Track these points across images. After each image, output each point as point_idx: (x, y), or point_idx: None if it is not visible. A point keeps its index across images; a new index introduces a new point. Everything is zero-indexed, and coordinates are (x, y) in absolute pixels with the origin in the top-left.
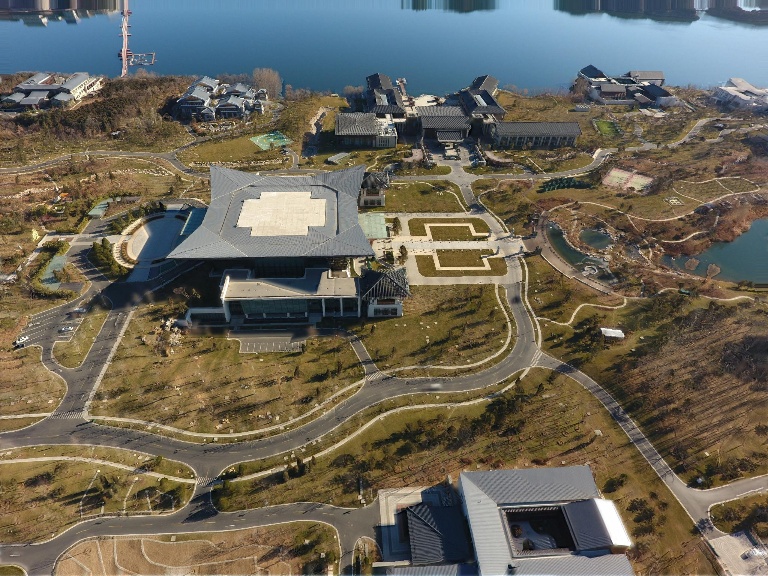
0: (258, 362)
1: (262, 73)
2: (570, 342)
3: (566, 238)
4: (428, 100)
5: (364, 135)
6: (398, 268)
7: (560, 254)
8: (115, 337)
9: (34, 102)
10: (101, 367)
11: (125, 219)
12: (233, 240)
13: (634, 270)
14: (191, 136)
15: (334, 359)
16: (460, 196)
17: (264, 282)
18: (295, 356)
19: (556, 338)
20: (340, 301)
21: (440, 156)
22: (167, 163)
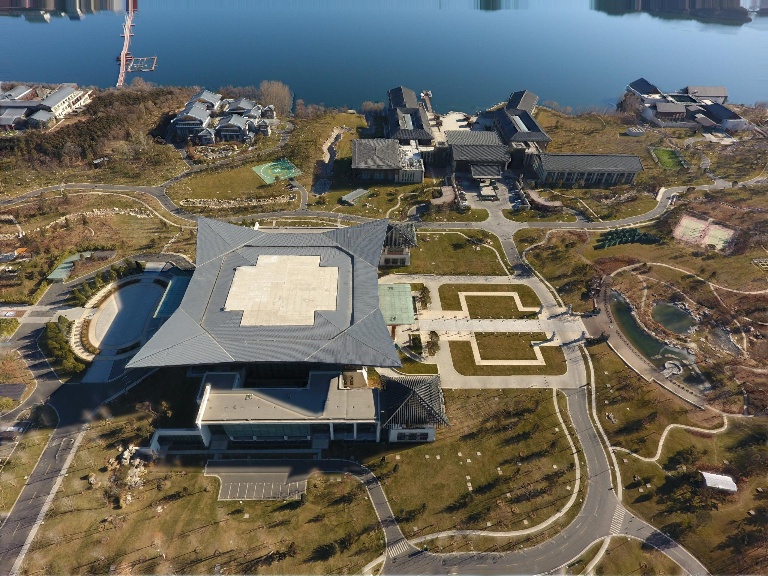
0: (241, 520)
1: (270, 86)
2: (662, 493)
3: (636, 316)
4: (457, 118)
5: (385, 169)
6: (427, 362)
7: (631, 341)
8: (54, 476)
9: (8, 122)
10: (28, 530)
11: (93, 284)
12: (218, 332)
13: (729, 368)
14: (185, 164)
15: (344, 516)
16: (501, 252)
17: (255, 394)
18: (292, 509)
19: (642, 485)
20: (353, 424)
21: (474, 195)
22: (154, 200)
